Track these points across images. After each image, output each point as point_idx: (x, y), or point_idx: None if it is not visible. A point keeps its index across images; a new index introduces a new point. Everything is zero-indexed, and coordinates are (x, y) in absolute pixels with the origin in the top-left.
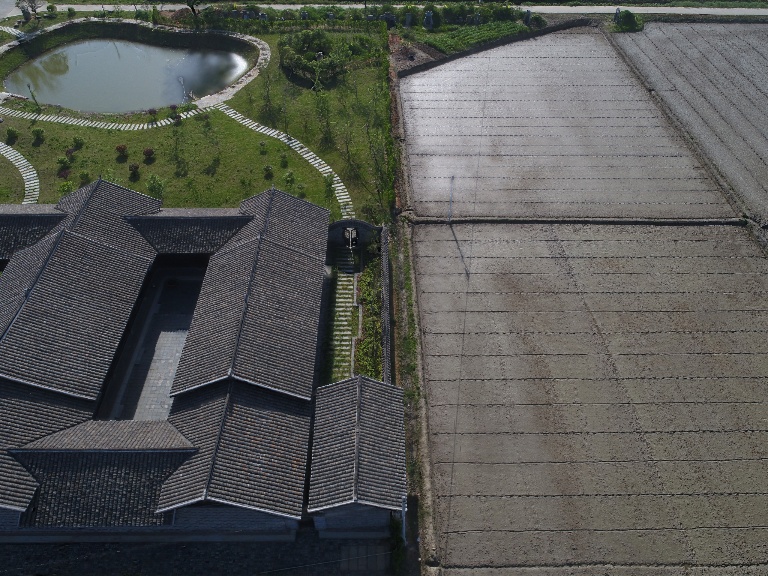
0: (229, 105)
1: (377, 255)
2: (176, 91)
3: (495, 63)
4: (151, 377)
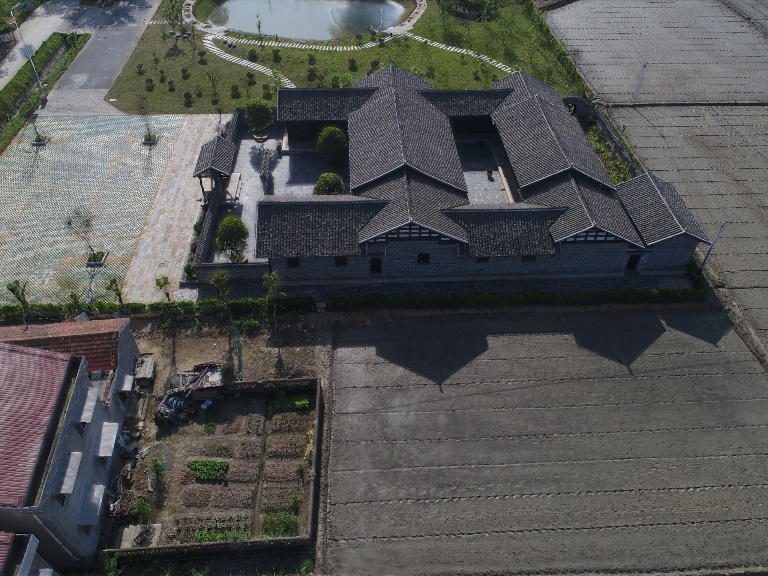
0: (414, 33)
1: (593, 124)
2: (355, 27)
3: (613, 2)
4: (468, 197)
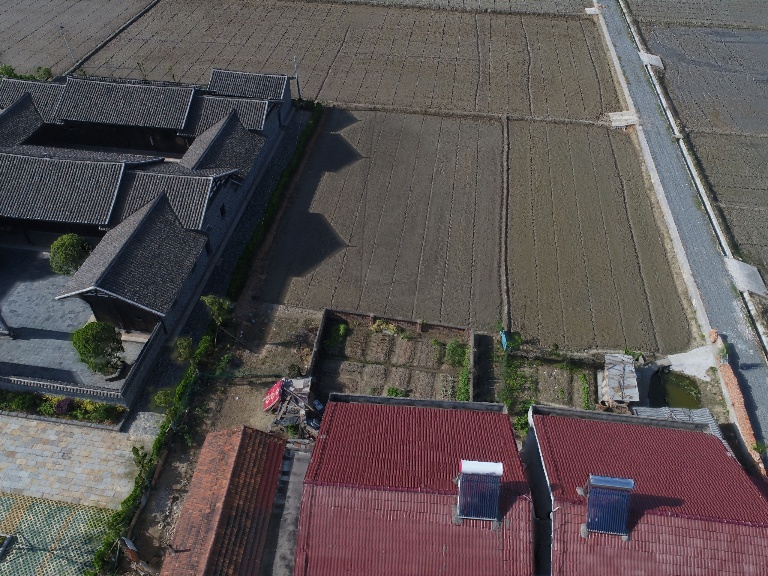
0: None
1: None
2: None
3: None
4: None
